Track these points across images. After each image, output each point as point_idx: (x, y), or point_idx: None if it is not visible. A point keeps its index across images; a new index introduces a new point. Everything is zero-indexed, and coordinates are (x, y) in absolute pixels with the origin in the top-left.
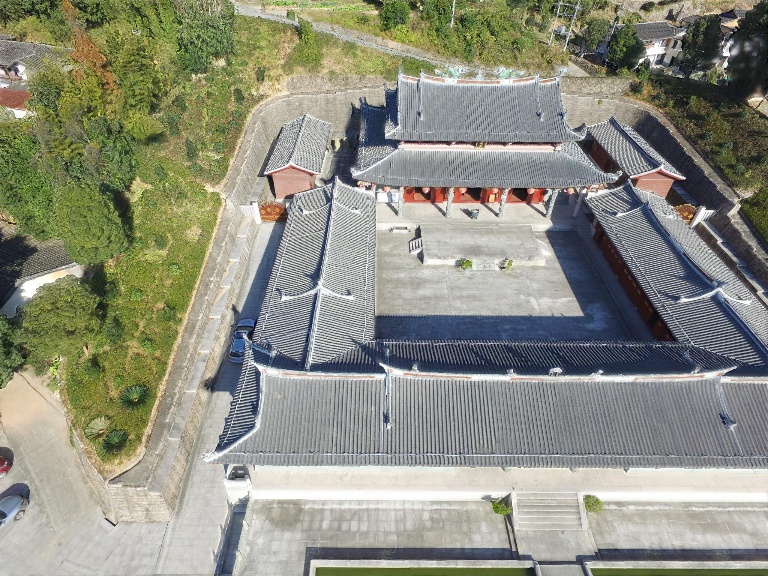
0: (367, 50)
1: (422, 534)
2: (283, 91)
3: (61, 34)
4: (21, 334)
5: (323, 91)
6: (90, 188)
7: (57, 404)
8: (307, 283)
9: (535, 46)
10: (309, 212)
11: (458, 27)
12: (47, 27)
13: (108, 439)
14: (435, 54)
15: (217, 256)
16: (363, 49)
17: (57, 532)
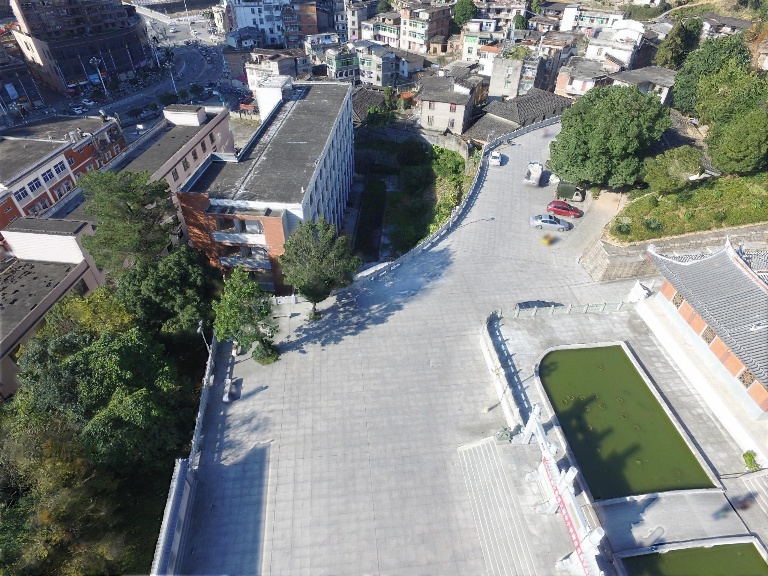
0: None
1: (684, 408)
2: None
3: None
4: (651, 159)
5: None
6: None
7: None
8: None
9: None
10: None
11: None
12: None
13: (622, 226)
14: None
15: None
16: None
17: (563, 245)
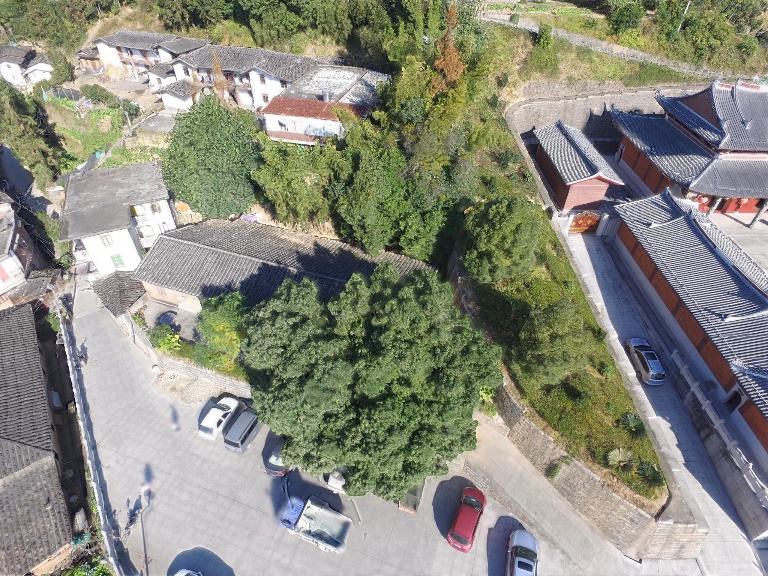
0: (602, 55)
1: None
2: (520, 97)
3: (267, 39)
4: (547, 362)
5: (561, 97)
6: (530, 205)
7: (497, 430)
8: (743, 303)
9: (760, 50)
10: (657, 225)
11: (686, 31)
12: (255, 32)
13: (644, 473)
14: (663, 58)
15: (579, 272)
16: (598, 54)
17: (585, 570)
